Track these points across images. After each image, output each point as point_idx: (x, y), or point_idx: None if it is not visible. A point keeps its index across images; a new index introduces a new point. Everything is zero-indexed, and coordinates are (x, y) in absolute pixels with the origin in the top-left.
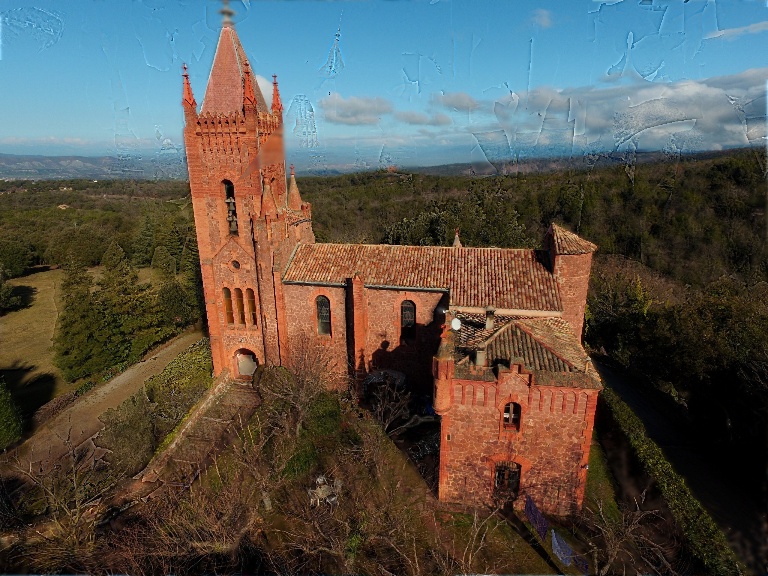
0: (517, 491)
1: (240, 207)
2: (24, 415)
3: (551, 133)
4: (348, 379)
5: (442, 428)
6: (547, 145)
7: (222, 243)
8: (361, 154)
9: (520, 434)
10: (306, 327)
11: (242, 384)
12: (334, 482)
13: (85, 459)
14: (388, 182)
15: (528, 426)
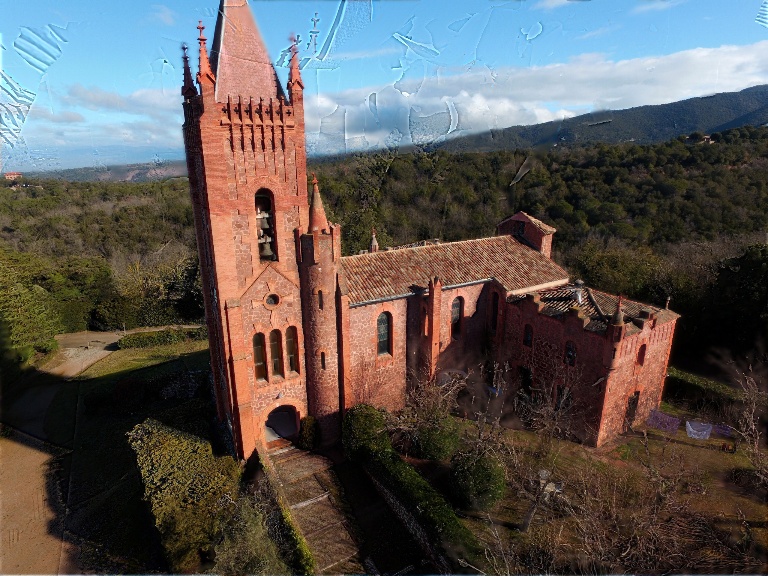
0: (634, 413)
1: (282, 223)
2: None
3: (327, 136)
4: (461, 385)
5: (607, 384)
6: (325, 147)
7: (255, 274)
8: (100, 155)
9: (643, 367)
10: (367, 352)
11: (282, 452)
12: (540, 475)
13: None
14: (178, 189)
15: (647, 359)
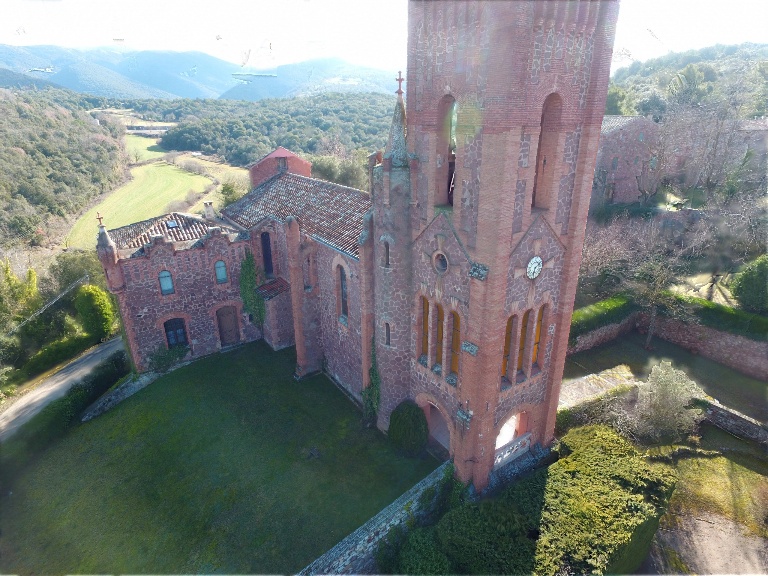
0: None
1: None
2: None
3: None
4: None
5: None
6: None
7: None
8: None
9: None
10: None
11: None
12: None
13: (762, 560)
14: None
15: None
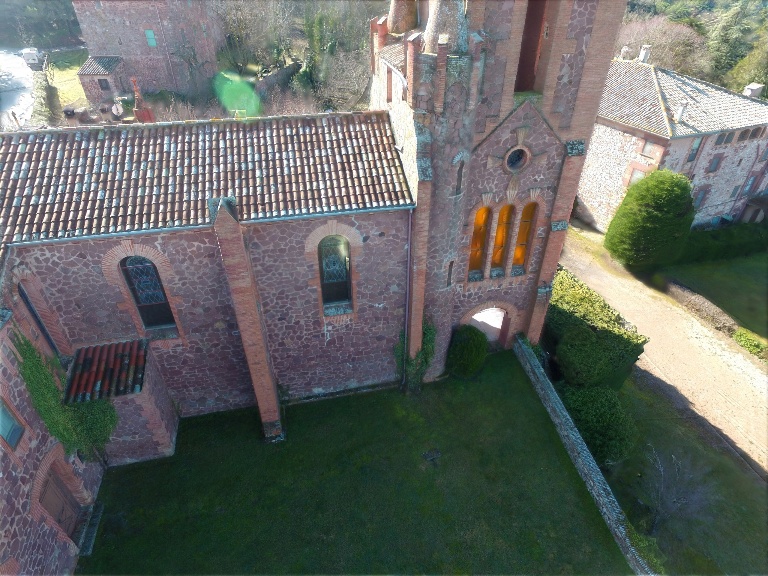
0: None
1: None
2: (724, 306)
3: None
4: None
5: None
6: None
7: None
8: None
9: None
10: None
11: None
12: None
13: None
14: None
15: None
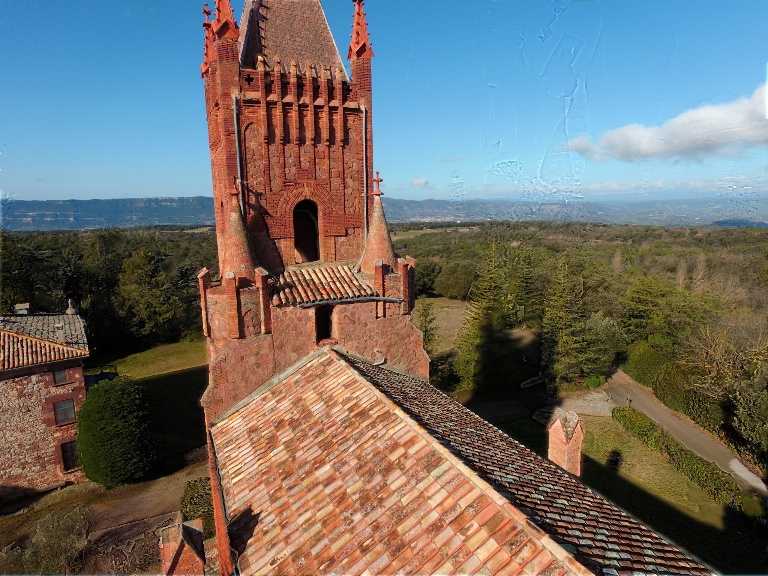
0: None
1: None
2: None
3: None
4: None
5: None
6: None
7: None
8: None
9: None
10: None
11: None
12: None
13: (124, 543)
14: None
15: None
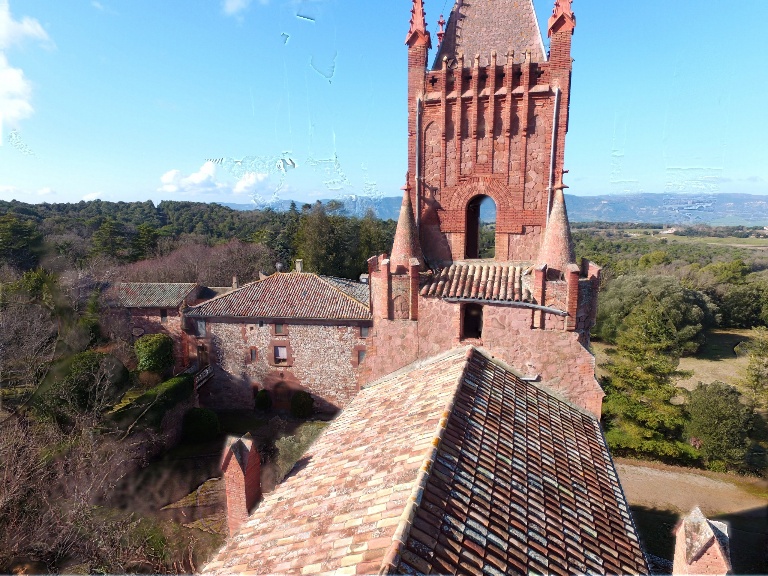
0: None
1: None
2: None
3: None
4: None
5: None
6: None
7: None
8: None
9: None
10: None
11: None
12: None
13: None
14: None
15: None
